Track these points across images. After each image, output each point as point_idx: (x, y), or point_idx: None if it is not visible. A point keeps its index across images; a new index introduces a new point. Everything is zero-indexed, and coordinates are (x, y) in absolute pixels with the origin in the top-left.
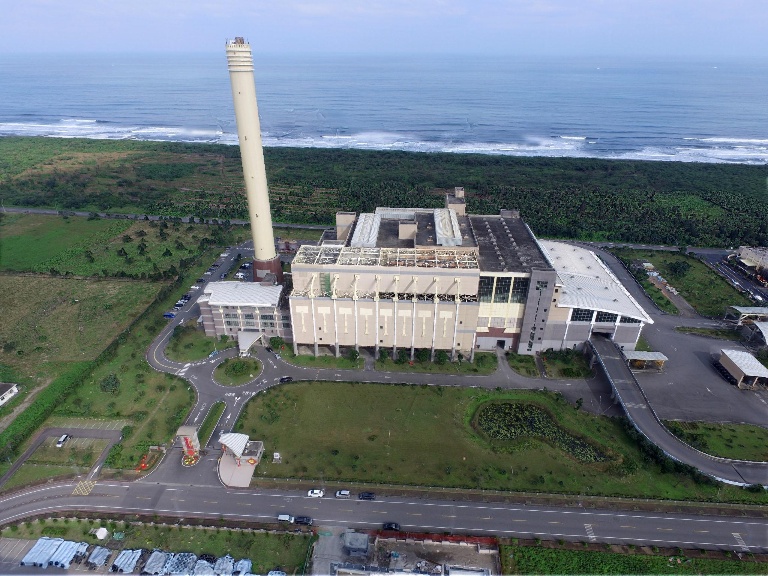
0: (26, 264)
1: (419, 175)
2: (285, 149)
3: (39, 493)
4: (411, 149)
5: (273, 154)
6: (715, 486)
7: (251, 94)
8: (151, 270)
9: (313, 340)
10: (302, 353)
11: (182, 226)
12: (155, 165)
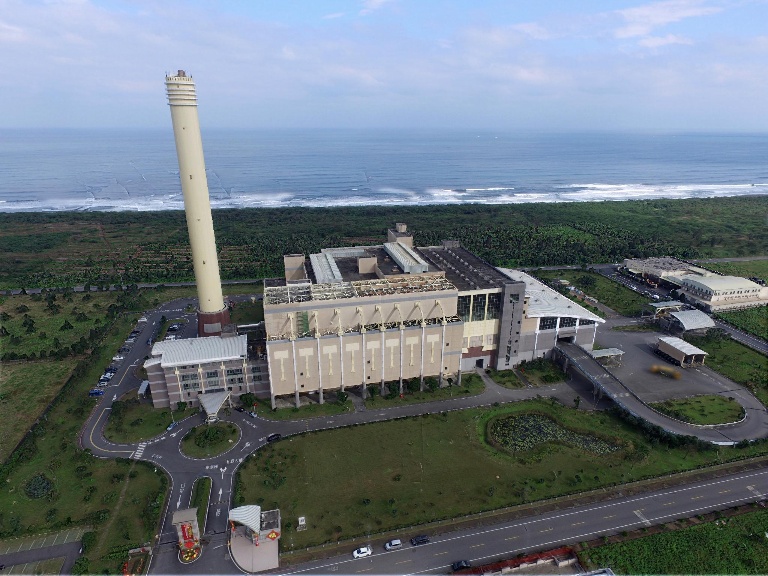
0: None
1: (327, 226)
2: (173, 212)
3: None
4: (309, 205)
5: (161, 217)
6: (713, 450)
7: (196, 130)
8: (50, 347)
9: (294, 389)
10: (280, 407)
11: (75, 296)
12: (13, 237)
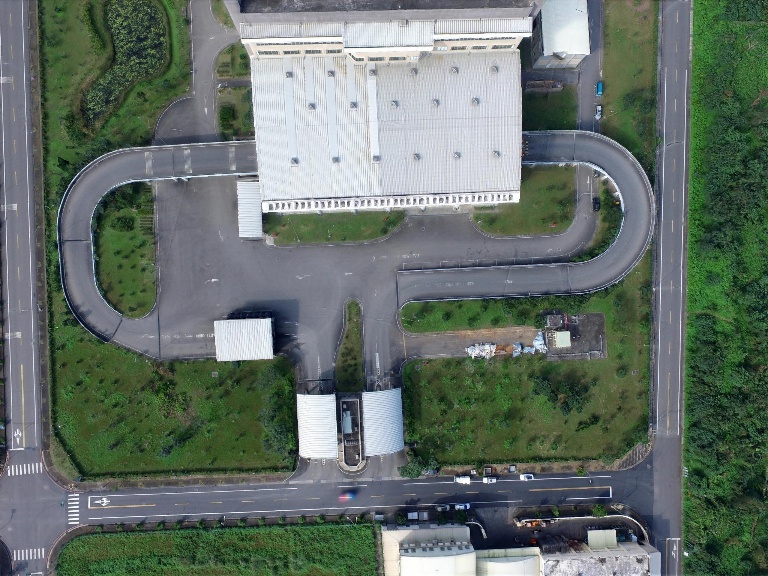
0: None
1: None
2: None
3: None
4: None
5: None
6: None
7: None
8: None
9: None
10: None
11: None
12: None
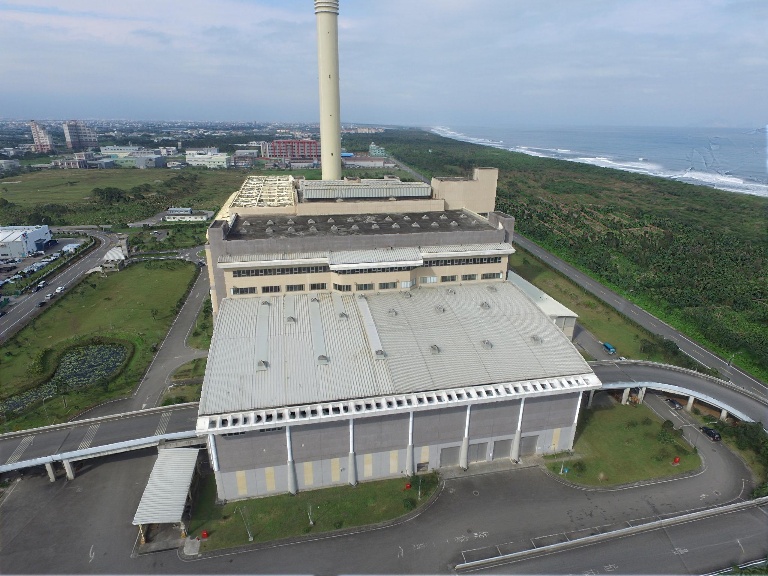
0: None
1: None
2: (739, 195)
3: (117, 239)
4: None
5: (710, 196)
6: None
7: (323, 34)
8: None
9: None
10: None
11: None
12: (573, 182)
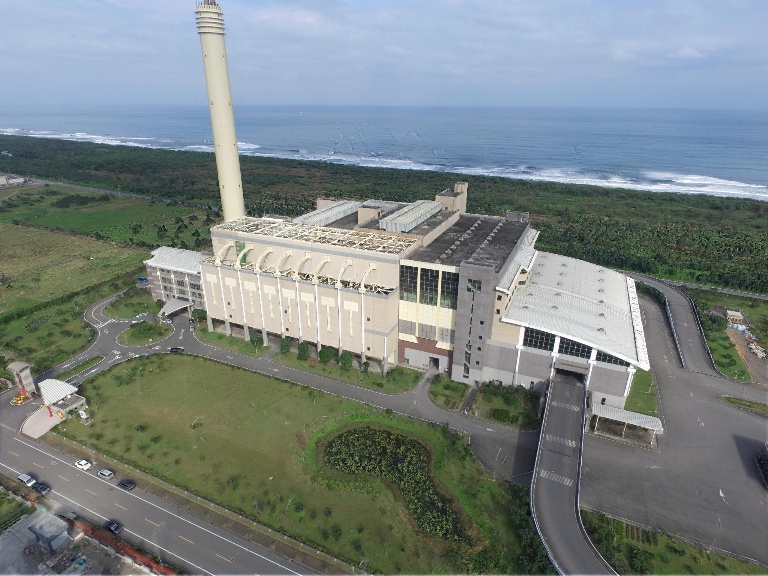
0: (89, 229)
1: (500, 198)
2: (383, 169)
3: None
4: (510, 175)
5: (369, 172)
6: None
7: (218, 58)
8: None
9: (224, 316)
10: (217, 330)
11: None
12: (262, 174)
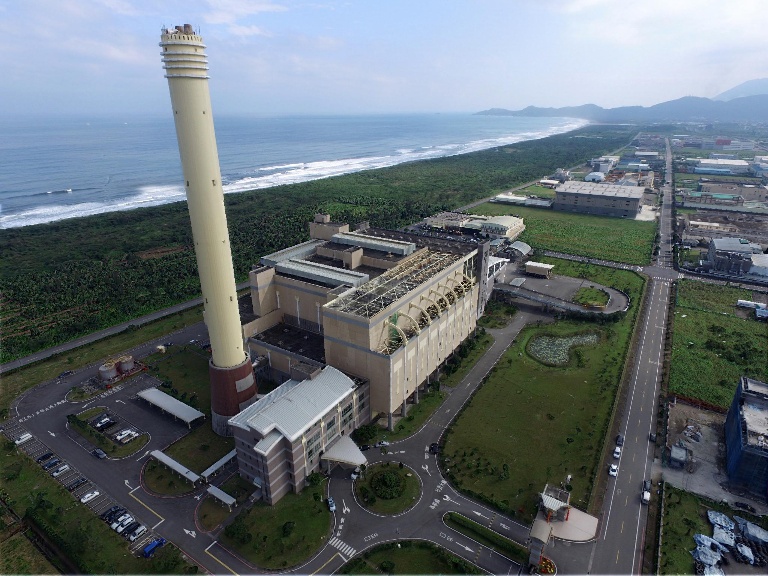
0: None
1: (93, 246)
2: None
3: None
4: (16, 224)
5: None
6: None
7: None
8: None
9: (402, 398)
10: None
11: None
12: None
